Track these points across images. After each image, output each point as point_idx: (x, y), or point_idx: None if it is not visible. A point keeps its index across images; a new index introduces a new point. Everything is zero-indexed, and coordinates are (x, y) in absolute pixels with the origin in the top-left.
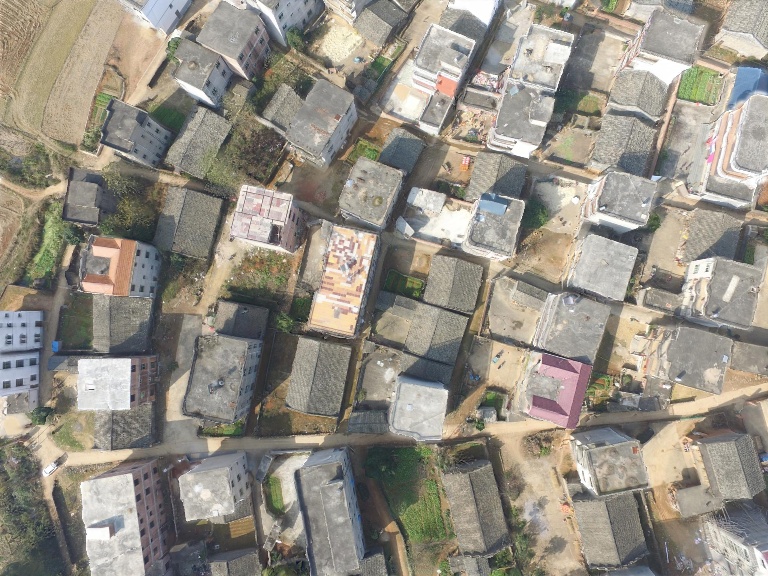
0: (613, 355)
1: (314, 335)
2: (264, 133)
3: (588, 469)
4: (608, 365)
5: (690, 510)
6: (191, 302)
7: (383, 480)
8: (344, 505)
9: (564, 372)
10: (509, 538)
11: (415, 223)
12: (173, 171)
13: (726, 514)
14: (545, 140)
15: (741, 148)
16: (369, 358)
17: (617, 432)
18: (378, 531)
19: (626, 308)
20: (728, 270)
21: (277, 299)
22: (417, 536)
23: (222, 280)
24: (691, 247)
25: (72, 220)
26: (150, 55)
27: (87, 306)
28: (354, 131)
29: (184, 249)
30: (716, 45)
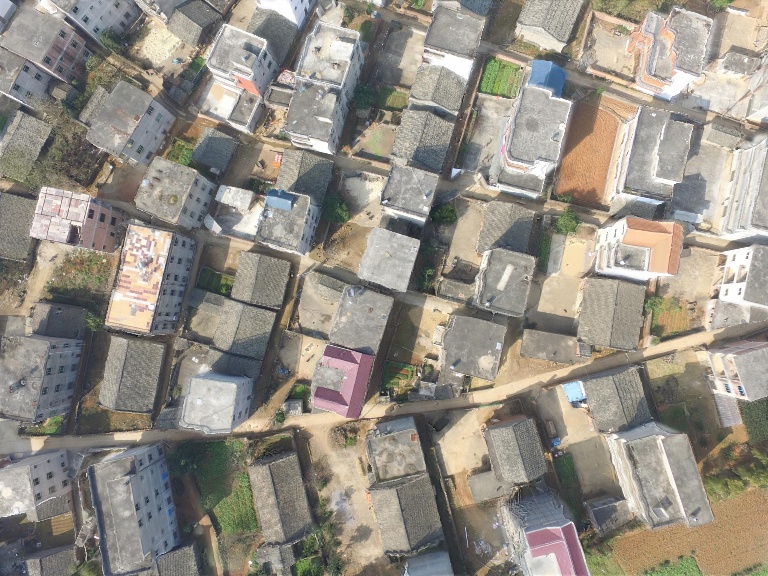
0: (417, 345)
1: None
2: (85, 135)
3: (368, 457)
4: (412, 355)
5: (482, 495)
6: (15, 304)
7: (197, 474)
8: (130, 499)
9: (345, 363)
10: (312, 528)
11: (229, 220)
12: None
13: (519, 498)
14: (355, 136)
15: (515, 139)
16: (184, 355)
17: (420, 421)
18: (192, 524)
19: (429, 299)
20: (503, 259)
21: (97, 299)
22: (229, 528)
23: (44, 281)
24: (484, 238)
25: None
26: None
27: None
28: (173, 131)
29: (0, 251)
30: (520, 39)
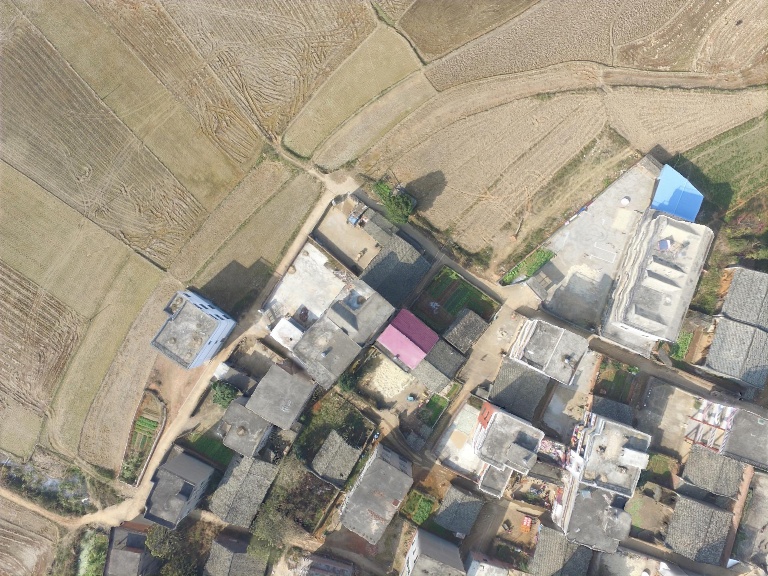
0: None
1: None
2: (313, 475)
3: None
4: None
5: None
6: None
7: None
8: None
9: None
10: None
11: None
12: None
13: None
14: None
15: None
16: None
17: None
18: None
19: None
20: None
21: None
22: None
23: None
24: None
25: None
26: (193, 379)
27: None
28: None
29: None
30: None
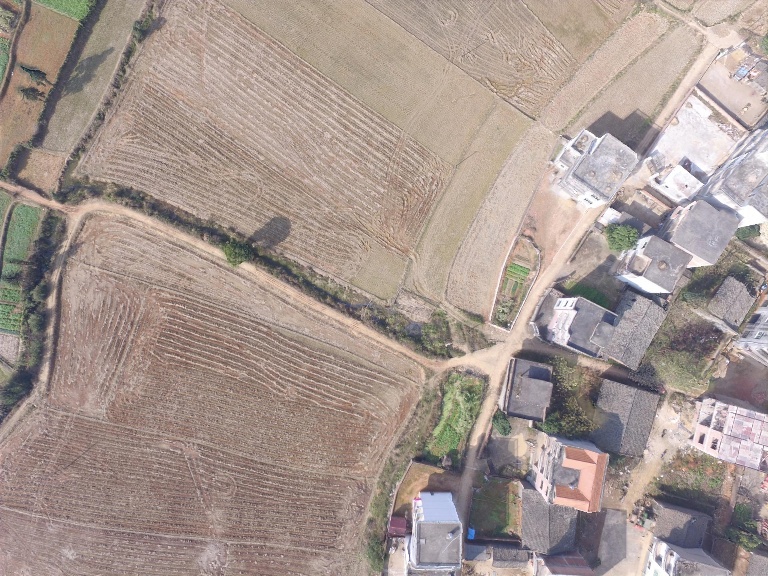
0: None
1: (758, 546)
2: (697, 323)
3: None
4: None
5: None
6: (614, 496)
7: None
8: None
9: None
10: None
11: None
12: (599, 357)
13: None
14: None
15: None
16: None
17: None
18: None
19: None
20: None
21: (712, 502)
22: None
23: (650, 477)
24: None
25: (517, 416)
26: (568, 227)
27: (499, 491)
28: None
29: (628, 450)
30: None
